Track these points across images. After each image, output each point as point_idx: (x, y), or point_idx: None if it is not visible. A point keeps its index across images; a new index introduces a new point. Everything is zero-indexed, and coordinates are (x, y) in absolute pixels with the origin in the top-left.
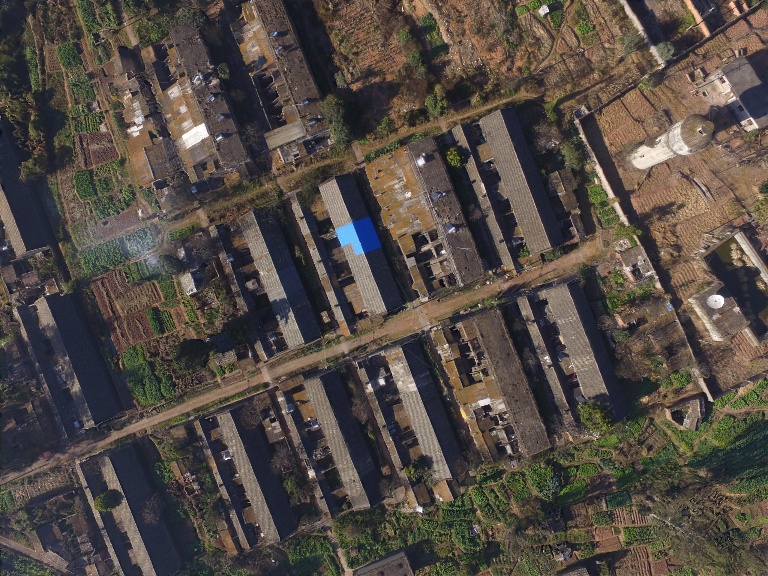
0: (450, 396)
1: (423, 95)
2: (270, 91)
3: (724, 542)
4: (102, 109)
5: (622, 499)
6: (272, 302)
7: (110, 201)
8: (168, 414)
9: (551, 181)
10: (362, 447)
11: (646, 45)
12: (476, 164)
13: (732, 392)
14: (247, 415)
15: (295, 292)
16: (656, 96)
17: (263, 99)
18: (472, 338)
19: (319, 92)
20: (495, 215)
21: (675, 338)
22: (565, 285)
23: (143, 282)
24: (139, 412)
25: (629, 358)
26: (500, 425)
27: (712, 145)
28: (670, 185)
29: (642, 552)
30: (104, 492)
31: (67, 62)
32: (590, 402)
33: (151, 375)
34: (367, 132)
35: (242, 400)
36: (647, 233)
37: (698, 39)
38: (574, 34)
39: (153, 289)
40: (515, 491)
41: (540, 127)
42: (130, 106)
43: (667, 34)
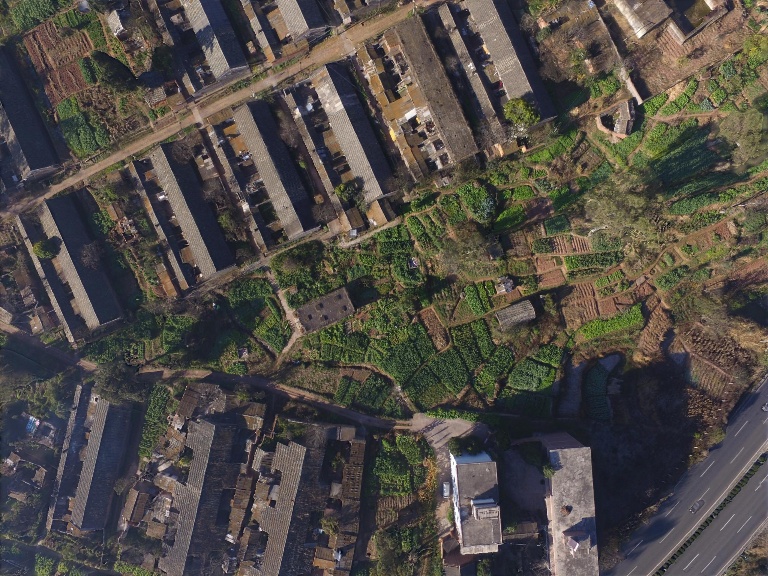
0: (379, 119)
1: None
2: None
3: (672, 279)
4: None
5: (560, 224)
6: (197, 33)
7: None
8: (104, 164)
9: None
10: (294, 175)
11: None
12: None
13: (662, 96)
14: (178, 149)
15: (219, 21)
16: None
17: None
18: (396, 53)
19: None
20: None
21: (598, 35)
22: None
23: (72, 29)
24: (76, 164)
25: (555, 64)
26: (428, 137)
27: None
28: None
29: (588, 289)
30: None
31: None
32: None
33: (85, 125)
34: None
35: None
36: None
37: None
38: None
39: (83, 39)
40: (450, 215)
41: None
42: None
43: None
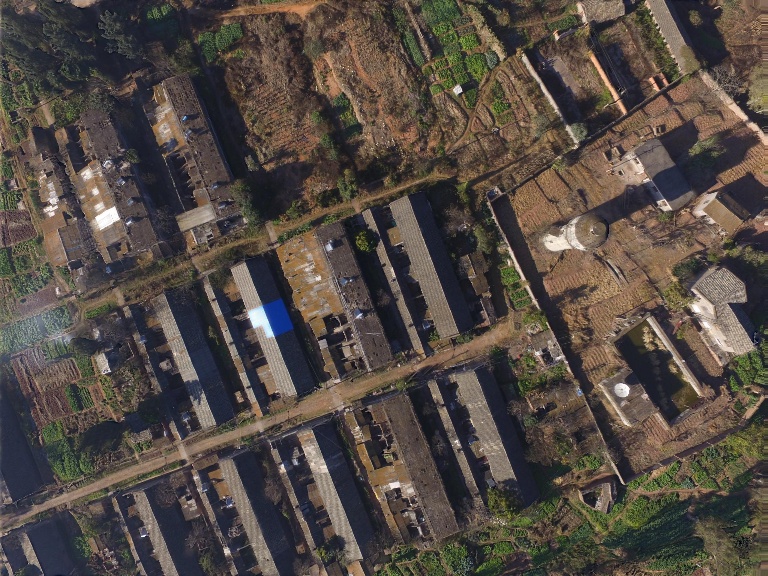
0: (364, 476)
1: (336, 176)
2: (184, 172)
3: None
4: (20, 187)
5: None
6: (185, 383)
7: (28, 279)
8: (87, 489)
9: (461, 265)
10: (276, 526)
11: (562, 123)
12: (385, 248)
13: (645, 474)
14: (162, 494)
15: (208, 373)
16: (571, 175)
17: (176, 180)
18: None
19: (230, 175)
20: (405, 299)
21: (585, 423)
22: (473, 371)
23: (60, 360)
24: (59, 487)
25: (540, 441)
26: (411, 507)
27: (627, 226)
28: (583, 267)
29: None
30: (24, 567)
31: None
32: (500, 486)
33: (70, 451)
34: (280, 212)
35: (160, 476)
36: (559, 316)
37: (615, 116)
38: (489, 113)
39: (71, 366)
40: (430, 570)
41: (450, 210)
42: (45, 186)
43: (584, 111)
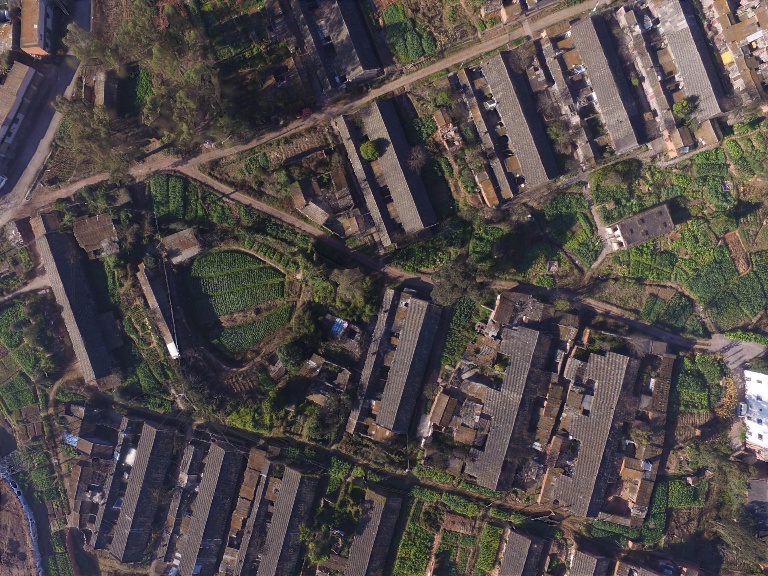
0: (712, 42)
1: None
2: None
3: None
4: None
5: None
6: None
7: None
8: (427, 71)
9: None
10: (627, 91)
11: None
12: None
13: None
14: (516, 57)
15: None
16: None
17: None
18: None
19: None
20: None
21: None
22: None
23: None
24: (398, 69)
25: None
26: (767, 60)
27: None
28: None
29: None
30: None
31: None
32: None
33: (412, 30)
34: None
35: None
36: None
37: None
38: None
39: None
40: None
41: None
42: None
43: None
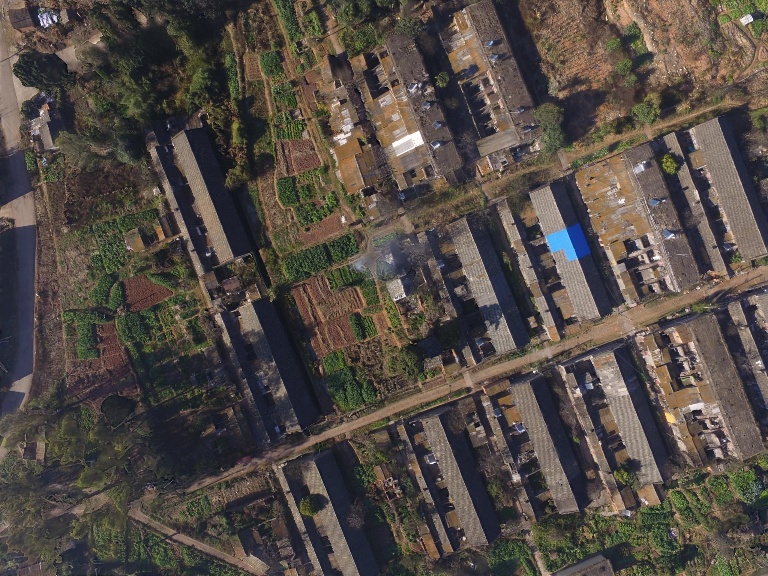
0: (655, 400)
1: (630, 103)
2: (477, 99)
3: None
4: (304, 117)
5: None
6: (481, 308)
7: (313, 208)
8: (368, 419)
9: (763, 188)
10: (568, 451)
11: None
12: (690, 171)
13: None
14: (455, 420)
15: (505, 298)
16: None
17: (471, 107)
18: None
19: (532, 100)
20: (708, 221)
21: None
22: None
23: (348, 288)
24: (339, 417)
25: None
26: (711, 429)
27: None
28: None
29: None
30: (306, 496)
31: (269, 70)
32: None
33: (352, 380)
34: (573, 139)
35: (443, 405)
36: None
37: None
38: None
39: (355, 295)
40: (717, 494)
41: (751, 135)
42: (338, 114)
43: None
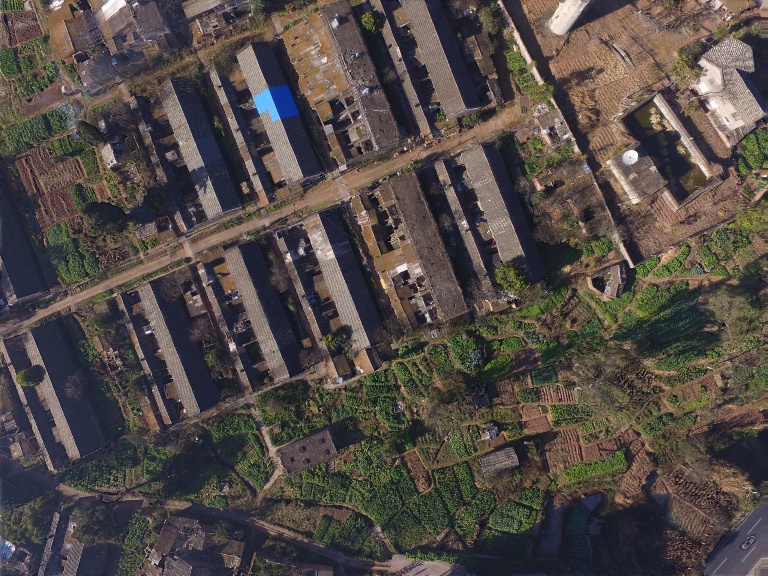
0: (370, 267)
1: None
2: None
3: (657, 427)
4: None
5: (548, 375)
6: (191, 172)
7: (34, 78)
8: (92, 291)
9: (467, 45)
10: (282, 318)
11: None
12: (391, 28)
13: (654, 260)
14: (167, 286)
15: (214, 161)
16: None
17: None
18: (390, 205)
19: None
20: (411, 79)
21: (593, 201)
22: (480, 146)
23: (65, 157)
24: (63, 290)
25: (548, 224)
26: (418, 292)
27: (632, 12)
28: (589, 51)
29: (572, 435)
30: None
31: None
32: None
33: (75, 252)
34: (286, 3)
35: None
36: (565, 98)
37: None
38: None
39: (76, 166)
40: (437, 364)
41: None
42: None
43: None
